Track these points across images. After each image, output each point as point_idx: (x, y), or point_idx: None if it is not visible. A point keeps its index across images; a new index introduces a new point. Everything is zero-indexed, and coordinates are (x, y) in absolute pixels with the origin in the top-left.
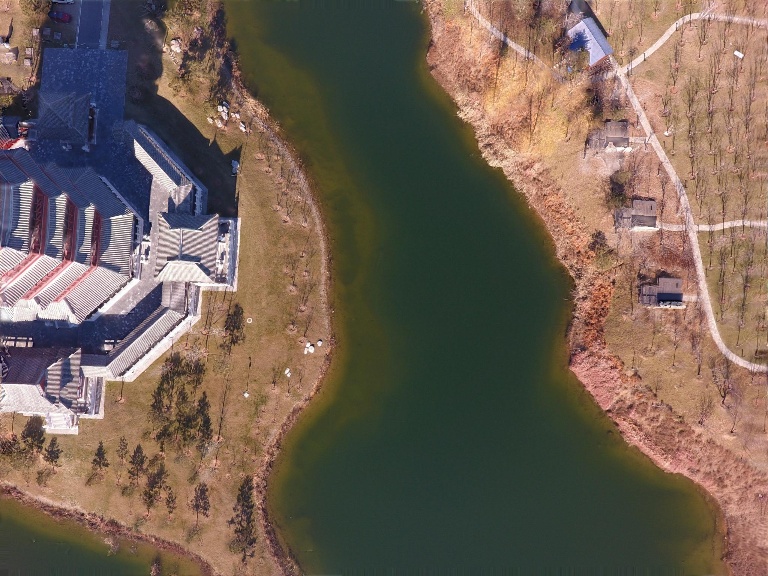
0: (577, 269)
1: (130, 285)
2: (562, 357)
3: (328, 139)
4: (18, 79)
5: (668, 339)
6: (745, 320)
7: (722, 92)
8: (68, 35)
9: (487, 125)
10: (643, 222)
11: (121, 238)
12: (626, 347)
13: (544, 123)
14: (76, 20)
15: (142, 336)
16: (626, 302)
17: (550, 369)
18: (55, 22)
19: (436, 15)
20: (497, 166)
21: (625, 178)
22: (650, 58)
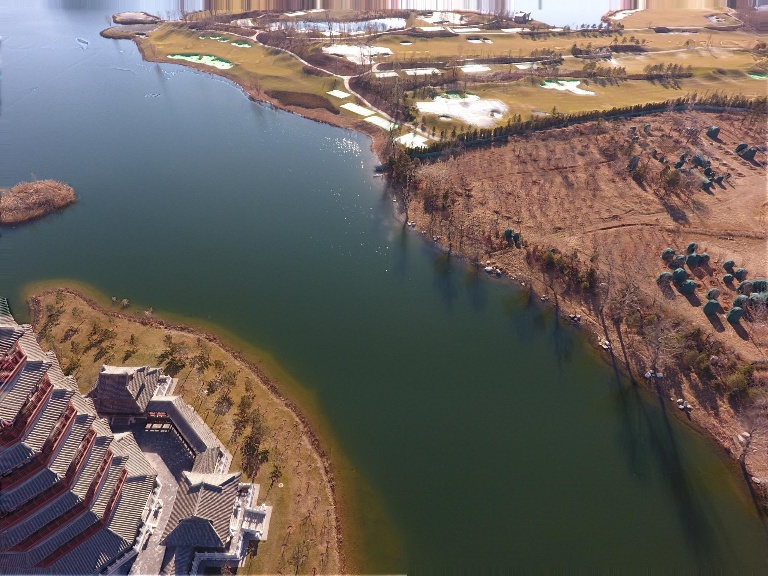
0: None
1: None
2: None
3: None
4: None
5: None
6: None
7: None
8: None
9: None
10: None
11: None
12: None
13: None
14: None
15: None
16: None
17: None
18: None
19: None
20: None
21: None
22: None
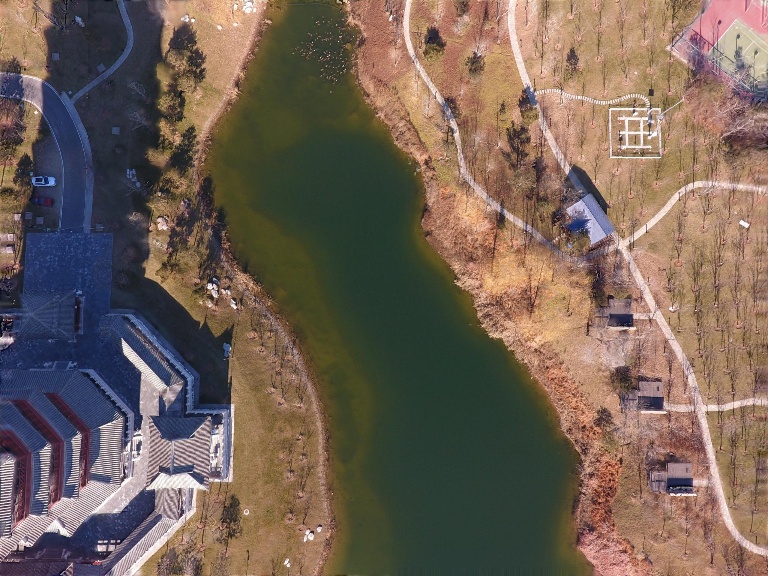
0: (583, 444)
1: (122, 484)
2: (569, 534)
3: (322, 309)
4: (1, 267)
5: (679, 526)
6: (758, 505)
7: (728, 264)
8: (51, 219)
9: (486, 294)
10: (650, 403)
11: (111, 445)
12: (636, 531)
13: (544, 296)
14: (59, 203)
15: (136, 546)
16: (634, 484)
17: (557, 546)
18: (37, 206)
19: (430, 180)
20: (497, 337)
21: (630, 362)
22: (652, 230)
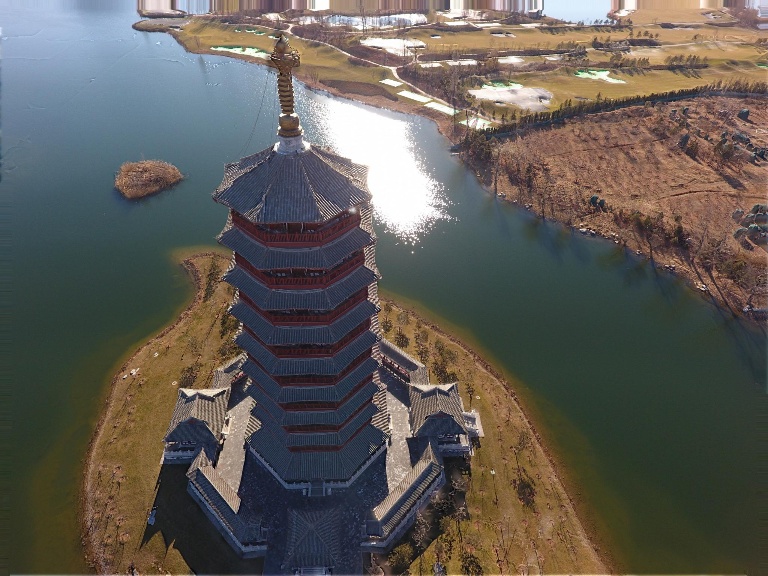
0: None
1: None
2: None
3: None
4: None
5: None
6: None
7: None
8: None
9: None
10: None
11: None
12: None
13: None
14: None
15: None
16: None
17: None
18: None
19: None
20: None
21: None
22: None
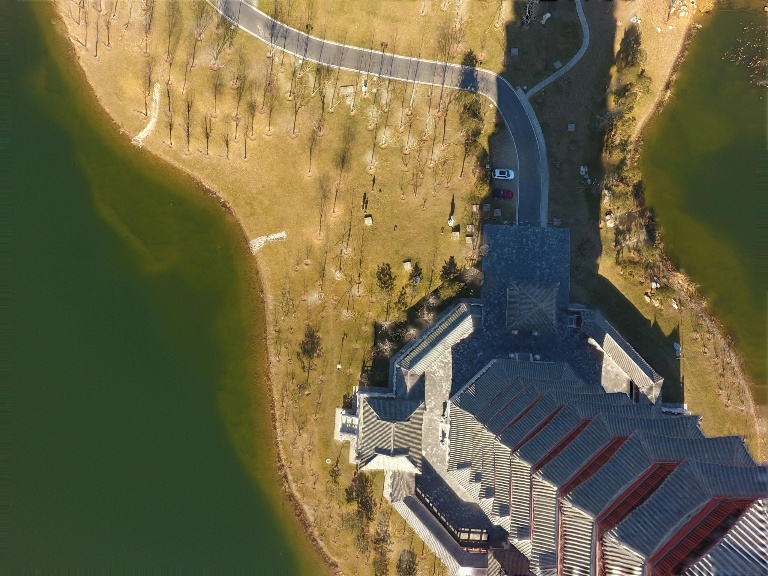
0: None
1: None
2: None
3: (752, 313)
4: (460, 257)
5: None
6: None
7: None
8: (508, 212)
9: None
10: None
11: None
12: None
13: None
14: (515, 196)
15: None
16: None
17: None
18: (495, 198)
19: None
20: None
21: None
22: None
